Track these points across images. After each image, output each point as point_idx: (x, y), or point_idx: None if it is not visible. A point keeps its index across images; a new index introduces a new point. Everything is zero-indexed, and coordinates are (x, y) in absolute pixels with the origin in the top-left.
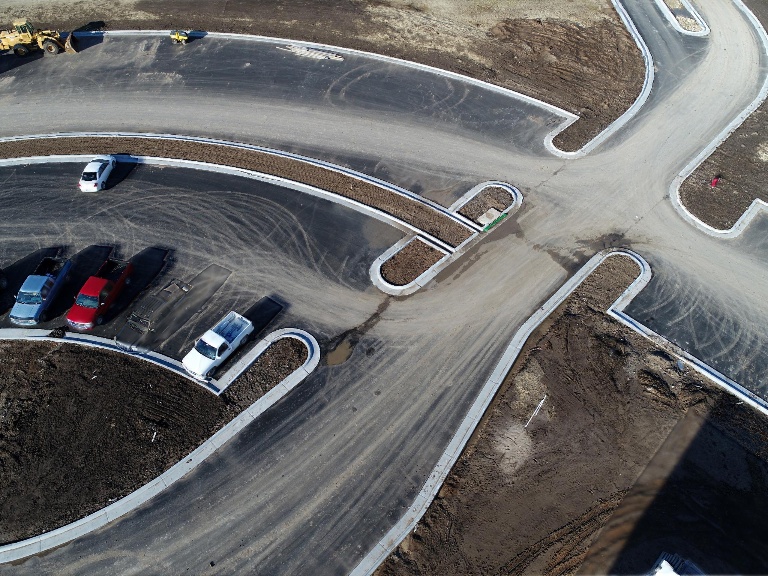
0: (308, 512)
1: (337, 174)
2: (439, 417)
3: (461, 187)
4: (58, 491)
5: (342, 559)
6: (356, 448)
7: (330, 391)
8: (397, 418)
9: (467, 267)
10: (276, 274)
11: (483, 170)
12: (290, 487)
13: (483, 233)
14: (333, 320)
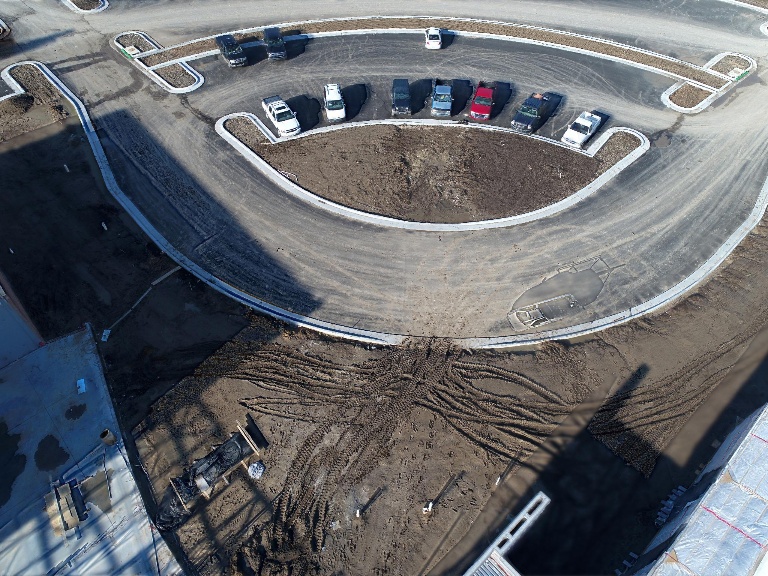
0: (683, 214)
1: (609, 45)
2: (749, 174)
3: (707, 55)
4: (514, 197)
5: (717, 235)
6: (699, 186)
7: (666, 159)
8: (720, 173)
9: (732, 100)
10: (595, 99)
11: (719, 46)
12: (664, 202)
13: (735, 82)
14: (649, 124)
